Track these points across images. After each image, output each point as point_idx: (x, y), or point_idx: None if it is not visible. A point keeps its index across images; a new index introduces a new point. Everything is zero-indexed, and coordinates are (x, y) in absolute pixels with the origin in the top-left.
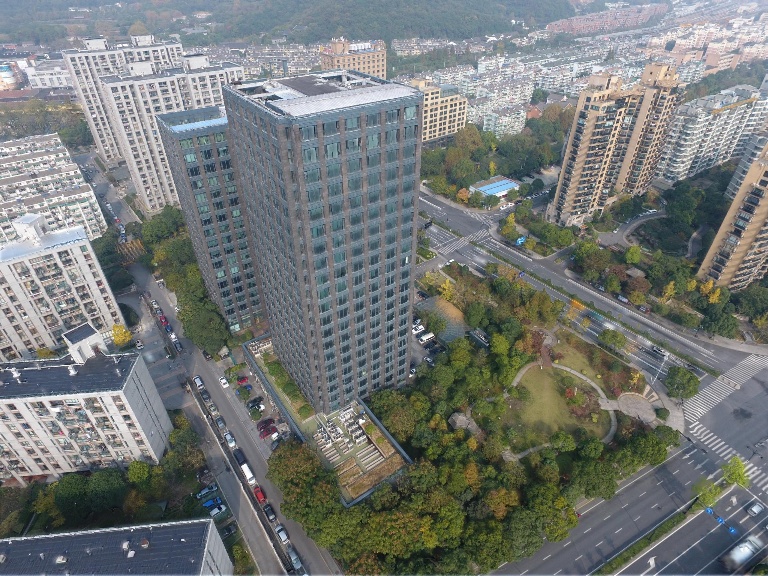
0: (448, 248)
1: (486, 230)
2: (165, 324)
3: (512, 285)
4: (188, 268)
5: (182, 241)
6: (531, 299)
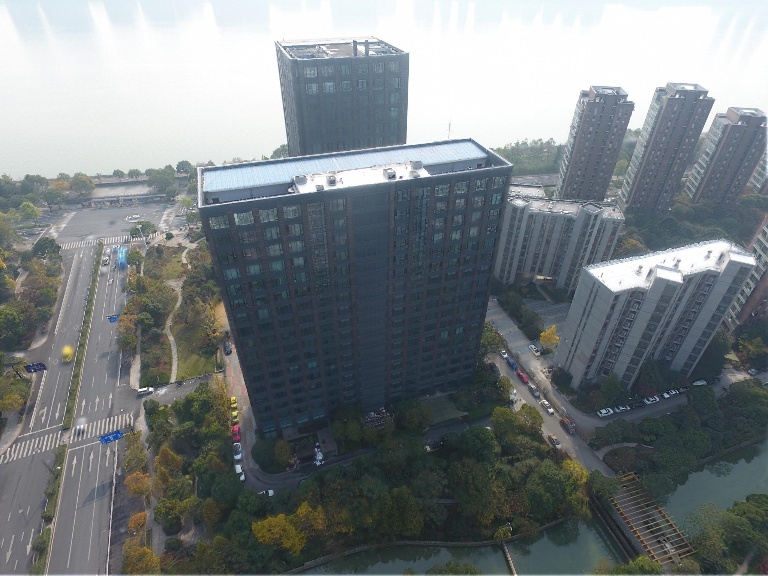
0: (114, 425)
1: (1, 458)
2: (519, 371)
3: (148, 302)
4: (511, 410)
5: (544, 472)
6: (149, 290)
